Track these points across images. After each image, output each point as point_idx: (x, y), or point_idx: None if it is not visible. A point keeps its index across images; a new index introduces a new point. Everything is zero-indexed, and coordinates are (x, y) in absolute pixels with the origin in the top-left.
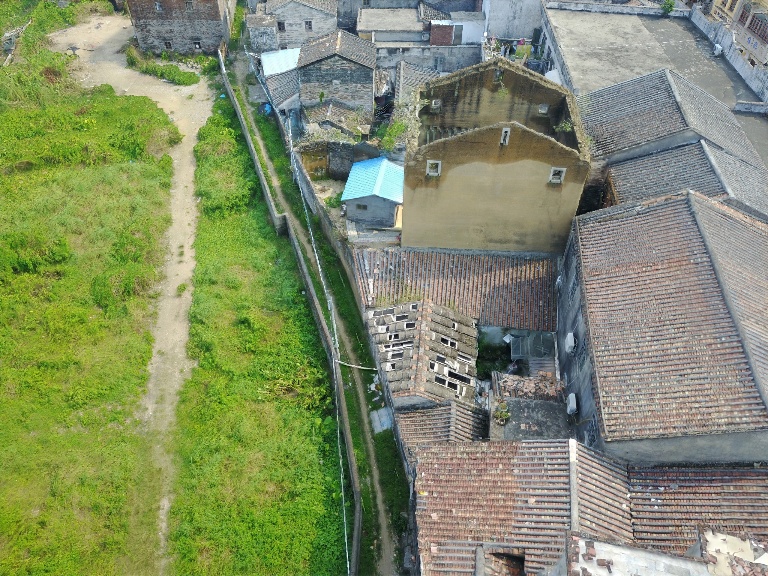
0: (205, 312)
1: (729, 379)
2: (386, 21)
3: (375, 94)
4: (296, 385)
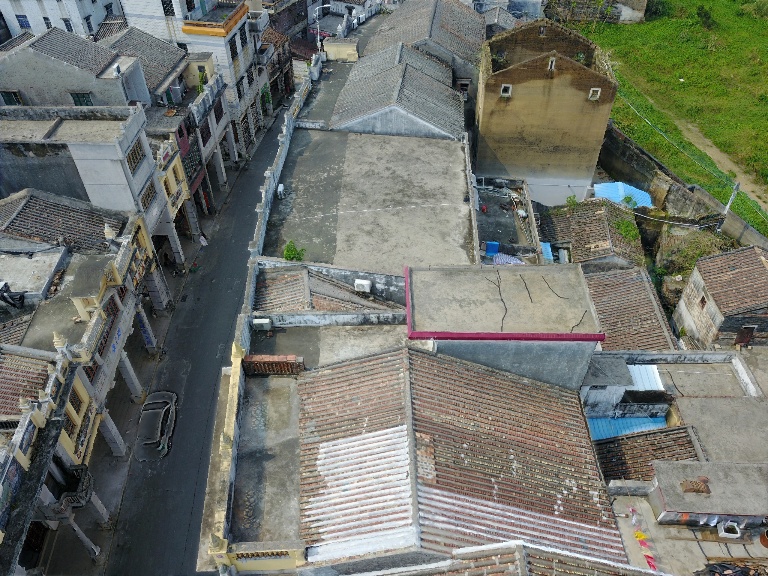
0: (699, 151)
1: (445, 2)
2: (759, 431)
3: (691, 338)
4: (616, 124)
